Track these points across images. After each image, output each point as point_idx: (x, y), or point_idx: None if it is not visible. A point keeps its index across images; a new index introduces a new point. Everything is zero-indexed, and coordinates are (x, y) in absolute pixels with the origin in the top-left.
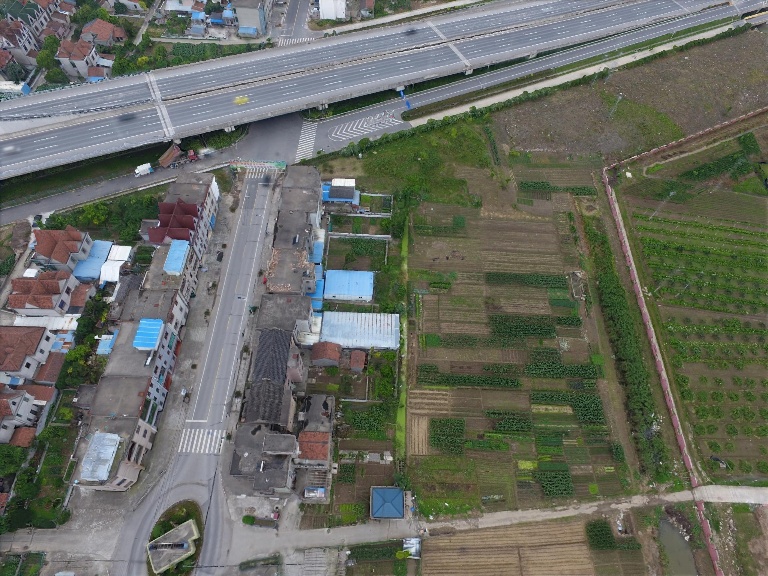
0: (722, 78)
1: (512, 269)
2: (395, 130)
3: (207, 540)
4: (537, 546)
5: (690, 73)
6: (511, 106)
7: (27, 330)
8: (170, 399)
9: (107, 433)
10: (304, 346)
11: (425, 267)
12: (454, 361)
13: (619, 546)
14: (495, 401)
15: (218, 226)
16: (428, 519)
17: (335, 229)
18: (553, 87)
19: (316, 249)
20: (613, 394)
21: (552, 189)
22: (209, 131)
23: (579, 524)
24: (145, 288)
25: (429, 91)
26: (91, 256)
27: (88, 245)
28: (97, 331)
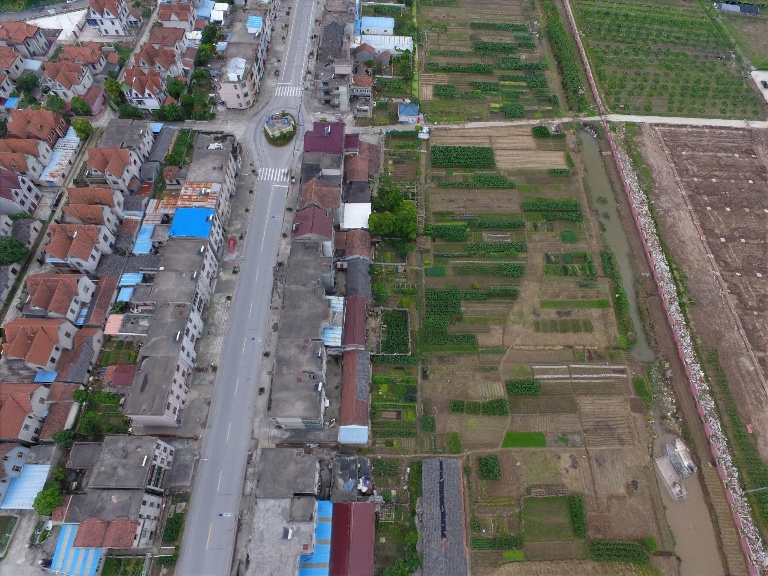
0: None
1: (489, 22)
2: None
3: (299, 129)
4: (501, 136)
5: None
6: None
7: None
8: (266, 74)
9: None
10: (350, 50)
11: None
12: (449, 62)
13: (552, 134)
14: (476, 79)
15: None
16: (434, 124)
17: None
18: None
19: None
20: (554, 77)
21: None
22: None
23: (528, 128)
24: (247, 8)
25: None
26: (203, 6)
27: None
28: None
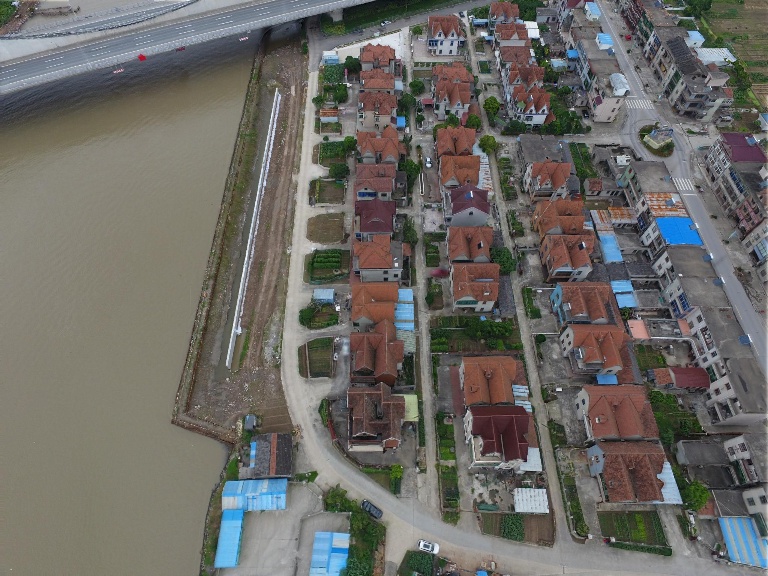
0: None
1: None
2: None
3: (672, 140)
4: None
5: None
6: None
7: None
8: None
9: None
10: None
11: None
12: None
13: None
14: None
15: None
16: None
17: None
18: None
19: None
20: None
21: None
22: None
23: None
24: (581, 26)
25: None
26: None
27: None
28: None
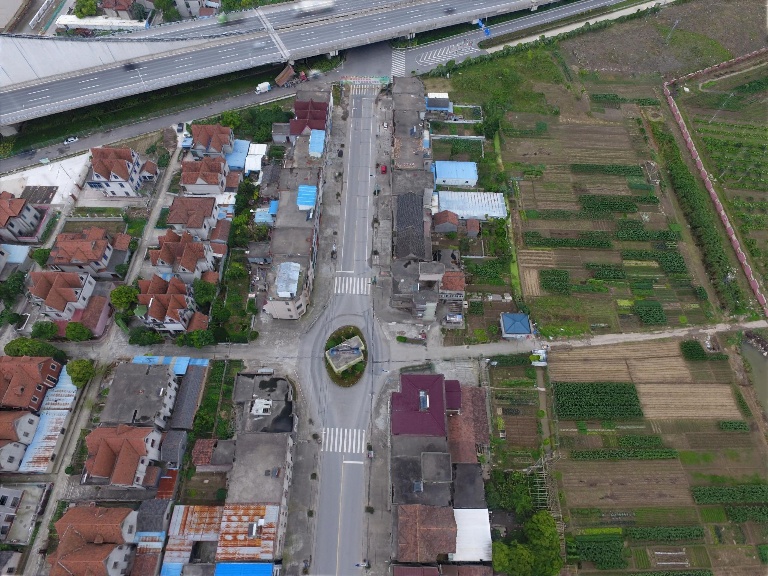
0: (764, 10)
1: (593, 162)
2: (474, 56)
3: (371, 353)
4: (641, 358)
5: (734, 7)
6: (575, 36)
7: (202, 198)
8: (320, 256)
9: (292, 262)
10: None
11: (517, 161)
12: (553, 229)
13: (710, 357)
14: (592, 258)
15: (334, 131)
16: (548, 339)
17: (435, 133)
18: (610, 21)
19: (424, 145)
20: (692, 253)
21: (620, 100)
22: (317, 54)
23: (674, 343)
24: (294, 166)
25: (500, 25)
26: (235, 151)
27: (232, 141)
28: (249, 208)
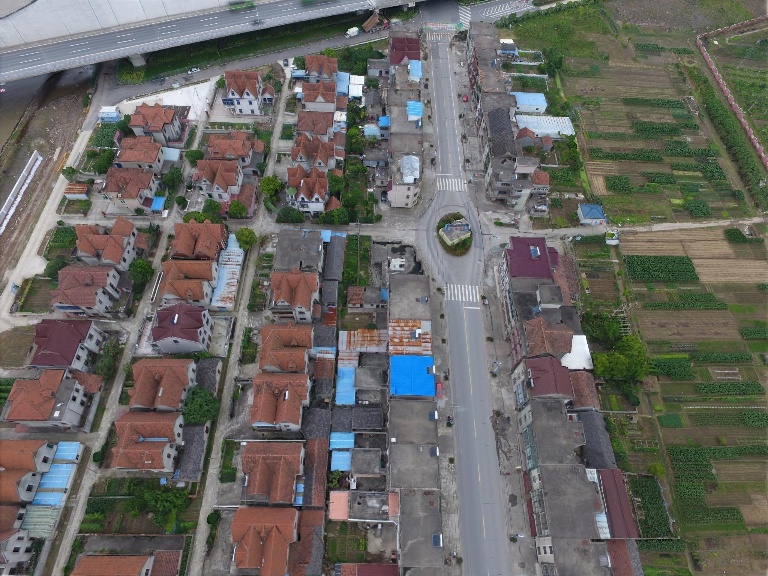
0: None
1: (641, 97)
2: None
3: (474, 233)
4: (693, 241)
5: None
6: None
7: None
8: None
9: None
10: None
11: None
12: (612, 147)
13: (749, 239)
14: (647, 168)
15: None
16: (618, 226)
17: (504, 71)
18: None
19: None
20: (729, 166)
21: (661, 49)
22: (398, 5)
23: (719, 231)
24: (398, 89)
25: None
26: (339, 80)
27: (337, 72)
28: None
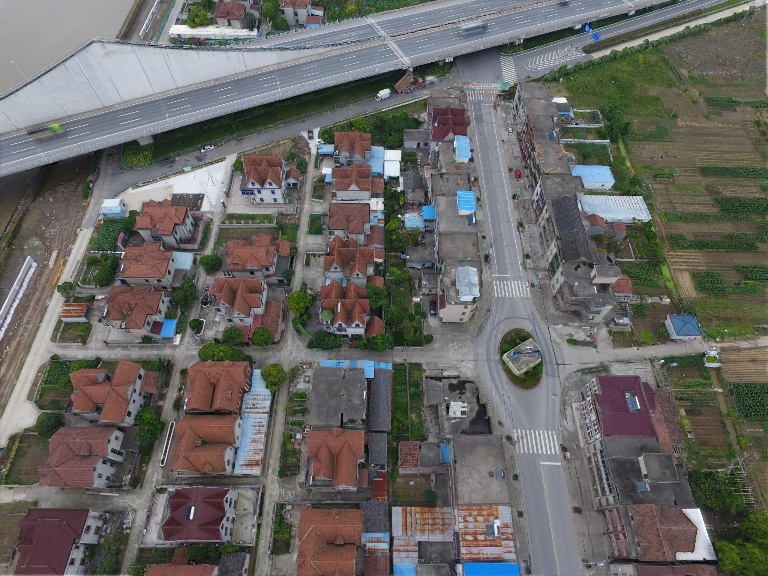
0: None
1: (720, 164)
2: (581, 61)
3: (544, 355)
4: None
5: None
6: (676, 40)
7: (358, 204)
8: None
9: None
10: None
11: (645, 164)
12: (695, 232)
13: None
14: (740, 260)
15: None
16: (715, 340)
17: None
18: None
19: None
20: None
21: (736, 103)
22: (434, 61)
23: None
24: (443, 172)
25: (600, 30)
26: (372, 157)
27: None
28: (395, 213)
